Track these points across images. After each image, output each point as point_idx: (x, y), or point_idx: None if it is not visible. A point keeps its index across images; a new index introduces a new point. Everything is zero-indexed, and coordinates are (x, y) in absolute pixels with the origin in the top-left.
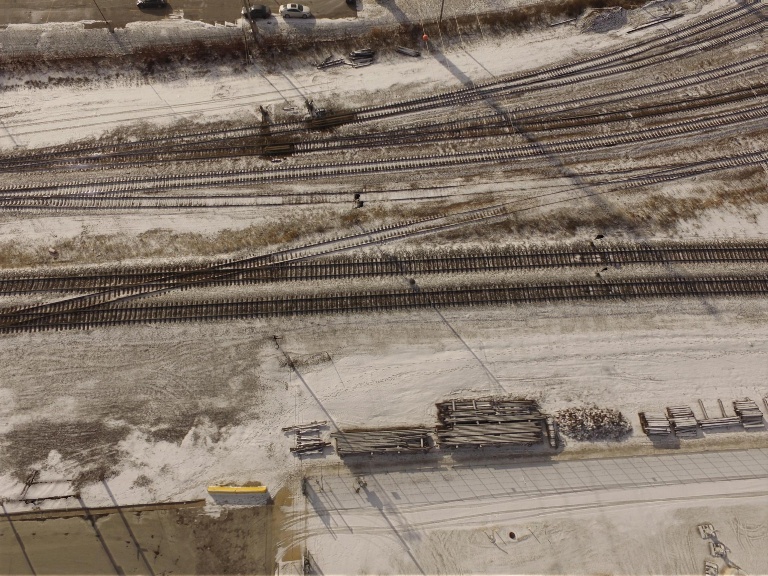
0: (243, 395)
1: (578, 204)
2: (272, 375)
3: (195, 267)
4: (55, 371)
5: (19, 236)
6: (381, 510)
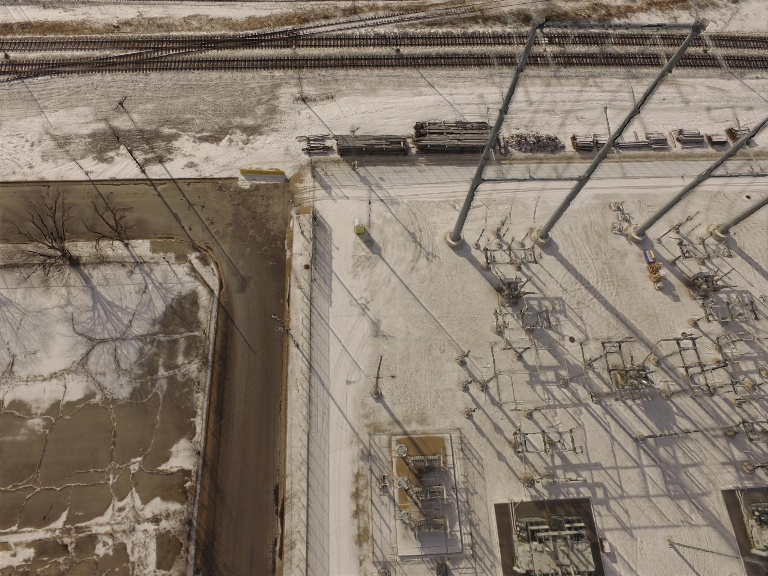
0: (266, 117)
1: (533, 6)
2: (288, 105)
3: (228, 37)
4: None
5: (89, 17)
6: (370, 187)
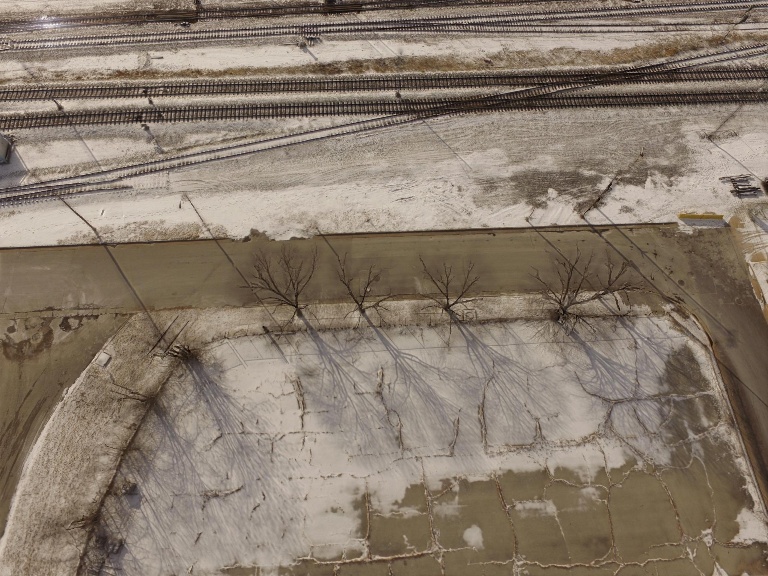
0: (679, 157)
1: None
2: (697, 144)
3: (607, 71)
4: (529, 138)
5: (455, 51)
6: None
